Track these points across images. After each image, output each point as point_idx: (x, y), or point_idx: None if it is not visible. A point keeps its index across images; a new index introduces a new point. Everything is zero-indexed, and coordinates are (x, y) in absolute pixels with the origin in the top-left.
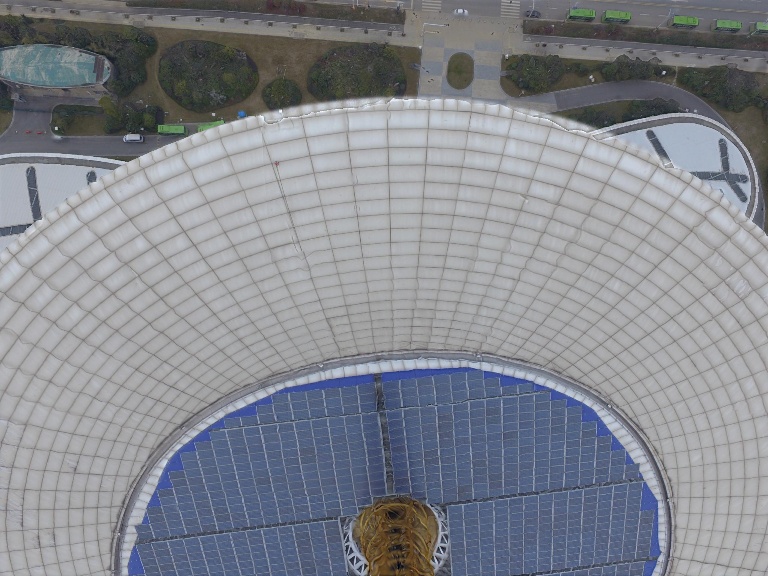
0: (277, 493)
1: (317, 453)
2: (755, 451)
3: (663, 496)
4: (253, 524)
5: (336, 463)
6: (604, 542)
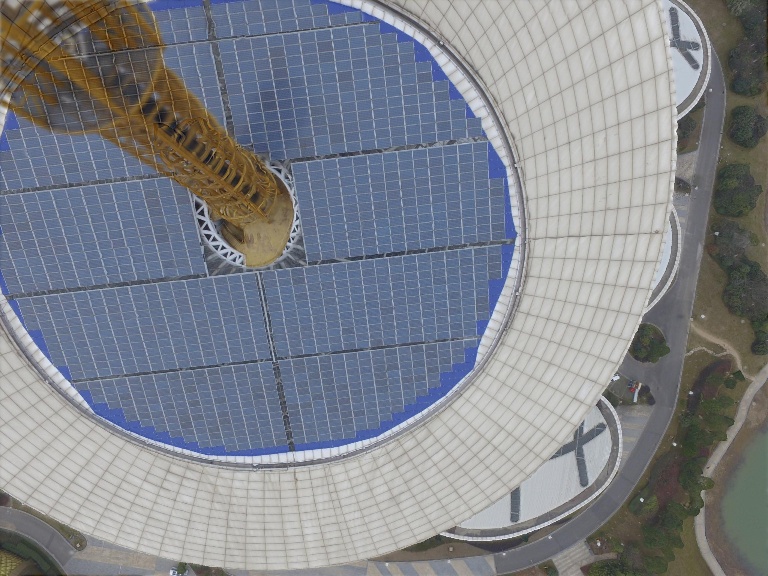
0: (121, 139)
1: (155, 90)
2: (580, 70)
3: (510, 160)
4: (102, 177)
5: (175, 104)
6: (456, 218)
